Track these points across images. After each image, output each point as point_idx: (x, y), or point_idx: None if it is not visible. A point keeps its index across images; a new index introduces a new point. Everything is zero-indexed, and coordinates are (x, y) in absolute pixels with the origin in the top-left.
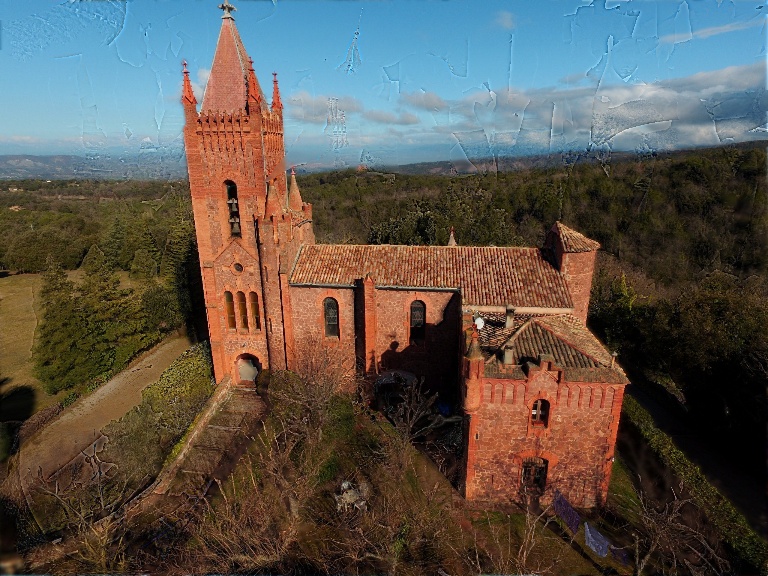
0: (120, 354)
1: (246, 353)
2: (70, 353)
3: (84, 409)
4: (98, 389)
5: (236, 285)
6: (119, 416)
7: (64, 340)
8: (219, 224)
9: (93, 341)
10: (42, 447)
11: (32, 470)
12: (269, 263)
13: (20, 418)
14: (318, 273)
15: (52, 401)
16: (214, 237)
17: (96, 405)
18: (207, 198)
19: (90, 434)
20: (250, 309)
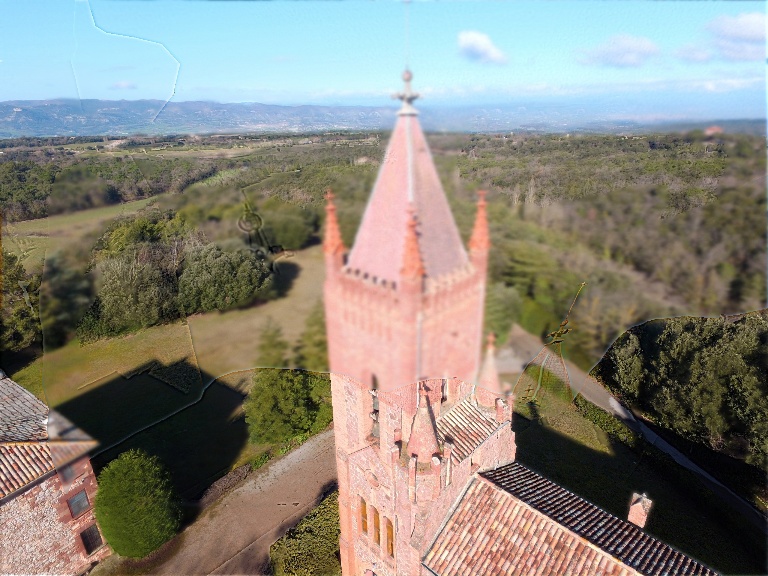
0: (321, 415)
1: (376, 574)
2: (271, 413)
3: (266, 481)
4: (290, 452)
5: (370, 496)
6: (281, 514)
7: (269, 399)
8: (356, 416)
9: (292, 406)
10: (211, 526)
11: (186, 562)
12: (400, 516)
13: (224, 464)
14: (473, 567)
15: (254, 450)
16: (351, 427)
17: (276, 480)
18: (345, 379)
19: (248, 531)
20: (384, 532)
